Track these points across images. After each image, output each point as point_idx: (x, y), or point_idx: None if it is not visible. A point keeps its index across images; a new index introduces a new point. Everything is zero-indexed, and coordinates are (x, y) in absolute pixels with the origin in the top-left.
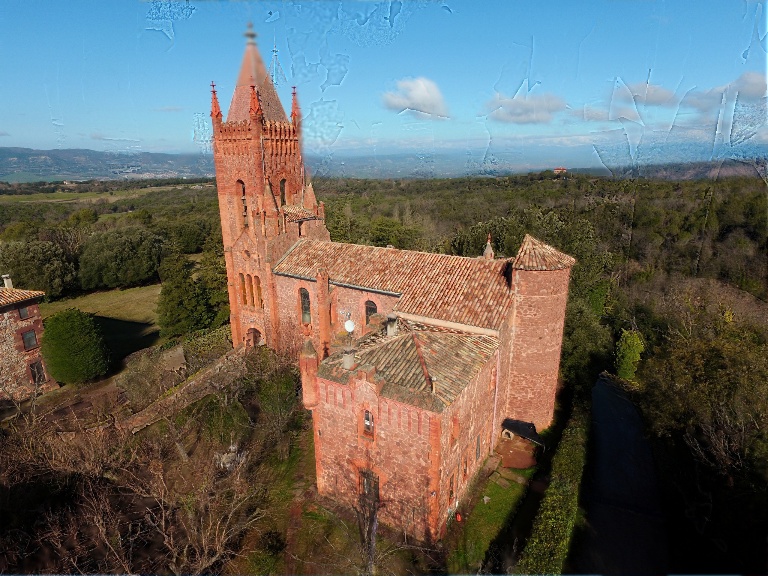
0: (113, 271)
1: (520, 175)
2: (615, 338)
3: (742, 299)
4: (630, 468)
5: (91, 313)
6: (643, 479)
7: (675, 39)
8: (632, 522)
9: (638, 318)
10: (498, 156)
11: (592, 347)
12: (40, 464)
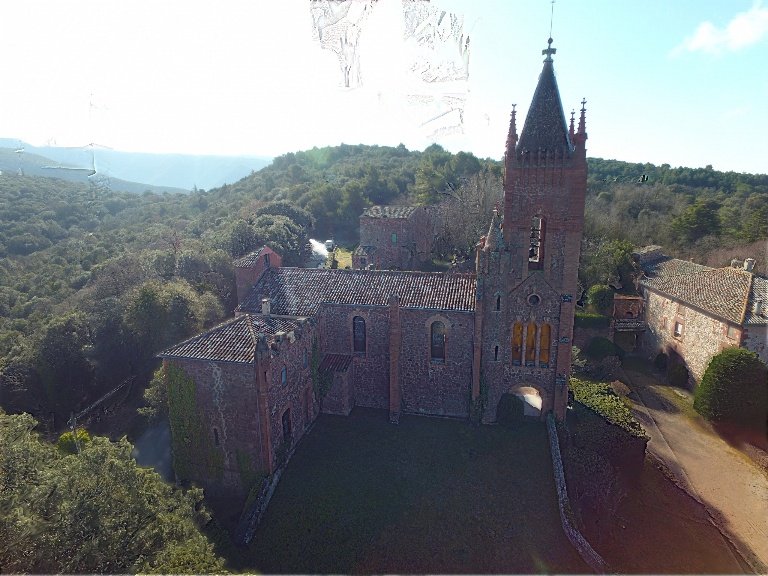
0: None
1: None
2: None
3: None
4: None
5: (744, 365)
6: None
7: None
8: None
9: None
10: None
11: None
12: None
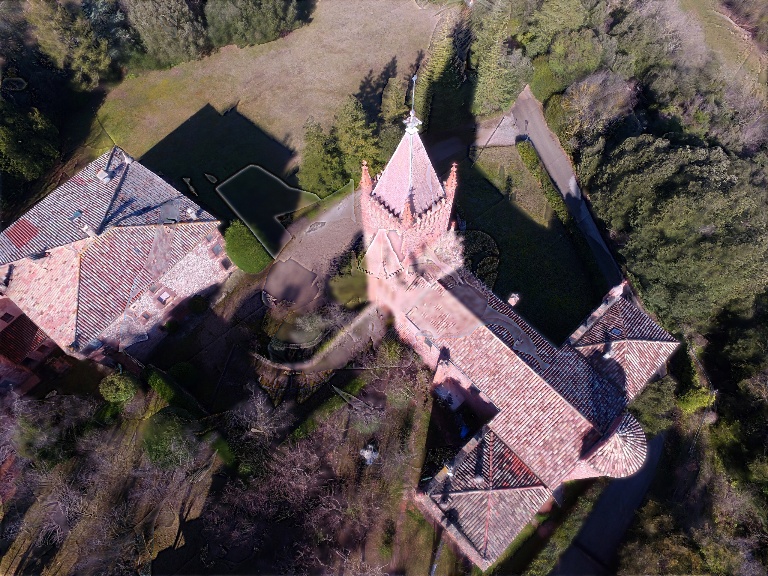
0: (241, 30)
1: None
2: (724, 314)
3: None
4: (613, 519)
5: None
6: (615, 532)
7: None
8: (585, 567)
9: (767, 298)
10: None
11: (648, 431)
12: (282, 499)
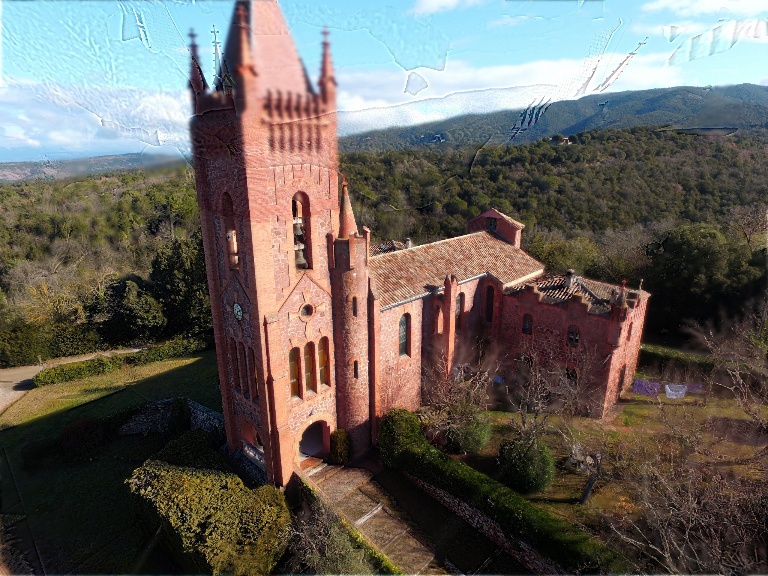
0: None
1: (75, 181)
2: None
3: None
4: None
5: None
6: None
7: None
8: None
9: None
10: (53, 157)
11: None
12: None
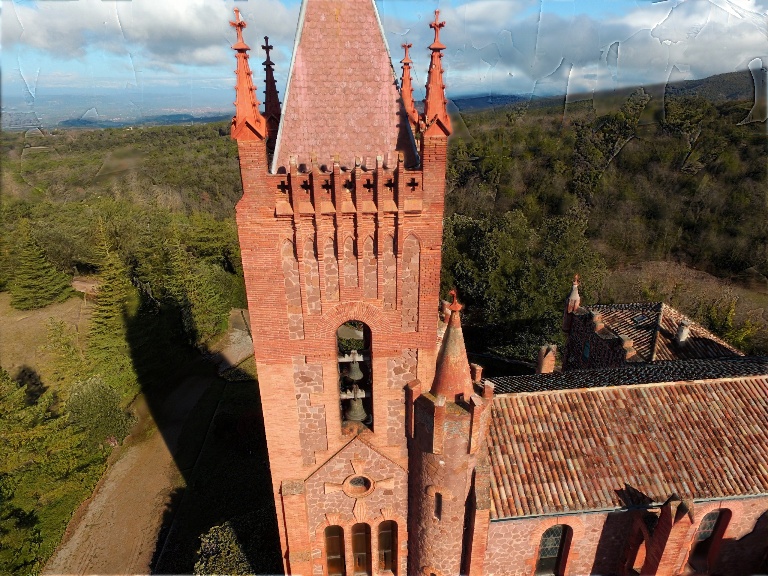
0: None
1: None
2: None
3: (703, 280)
4: None
5: None
6: None
7: (559, 3)
8: None
9: None
10: None
11: None
12: None
